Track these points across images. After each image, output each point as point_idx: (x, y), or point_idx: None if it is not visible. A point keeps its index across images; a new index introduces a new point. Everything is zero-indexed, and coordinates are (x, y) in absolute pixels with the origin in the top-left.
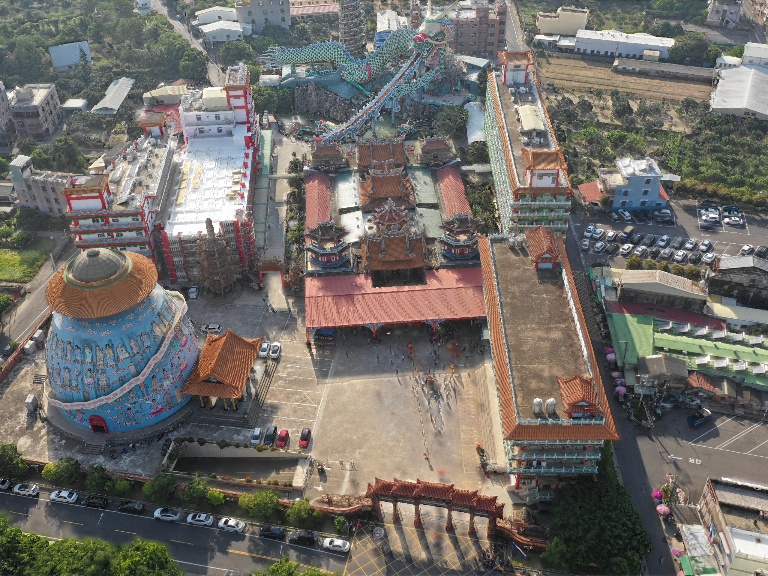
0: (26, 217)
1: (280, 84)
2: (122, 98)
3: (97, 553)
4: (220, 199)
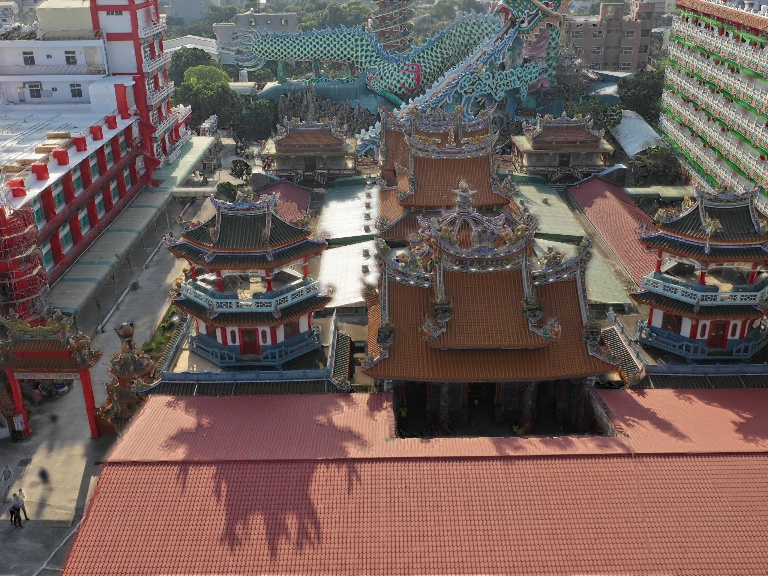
0: None
1: (255, 95)
2: None
3: None
4: None
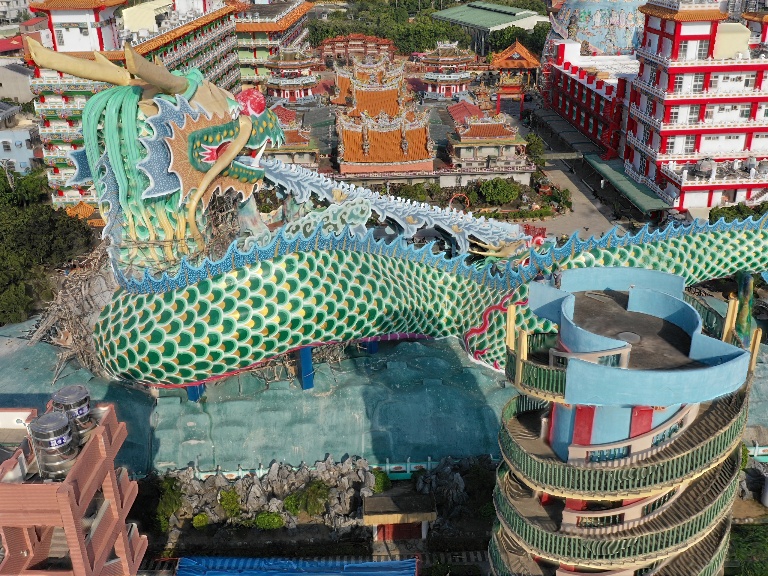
0: None
1: None
2: None
3: (538, 27)
4: None
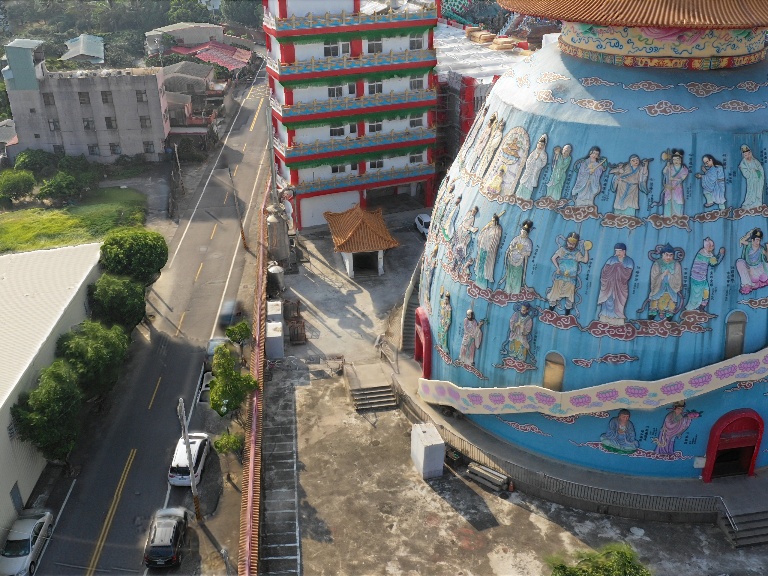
0: (45, 163)
1: None
2: (100, 50)
3: None
4: (490, 54)
